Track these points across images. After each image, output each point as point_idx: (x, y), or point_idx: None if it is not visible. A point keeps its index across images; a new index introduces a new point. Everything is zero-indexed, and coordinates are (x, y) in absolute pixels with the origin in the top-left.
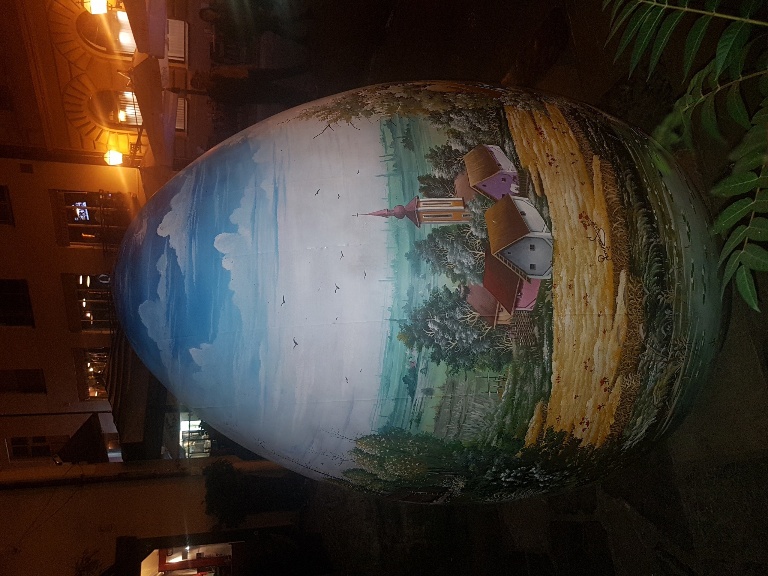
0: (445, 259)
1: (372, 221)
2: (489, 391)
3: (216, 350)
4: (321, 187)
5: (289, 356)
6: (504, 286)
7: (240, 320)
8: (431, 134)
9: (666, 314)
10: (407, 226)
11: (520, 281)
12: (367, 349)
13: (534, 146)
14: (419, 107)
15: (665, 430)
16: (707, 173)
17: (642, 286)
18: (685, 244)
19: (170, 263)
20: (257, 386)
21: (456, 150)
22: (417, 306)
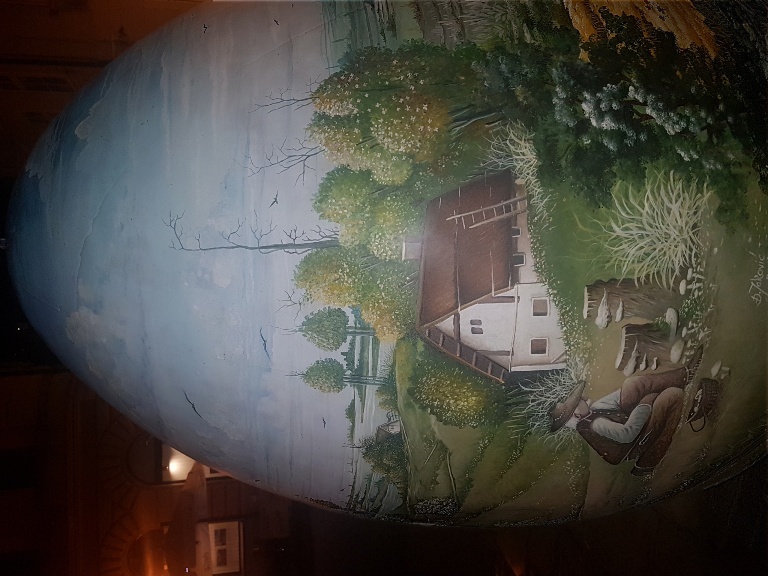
0: None
1: None
2: None
3: (108, 100)
4: None
5: (199, 41)
6: None
7: (140, 54)
8: None
9: None
10: None
11: None
12: None
13: None
14: None
15: None
16: None
17: None
18: None
19: None
20: (158, 99)
21: None
22: None
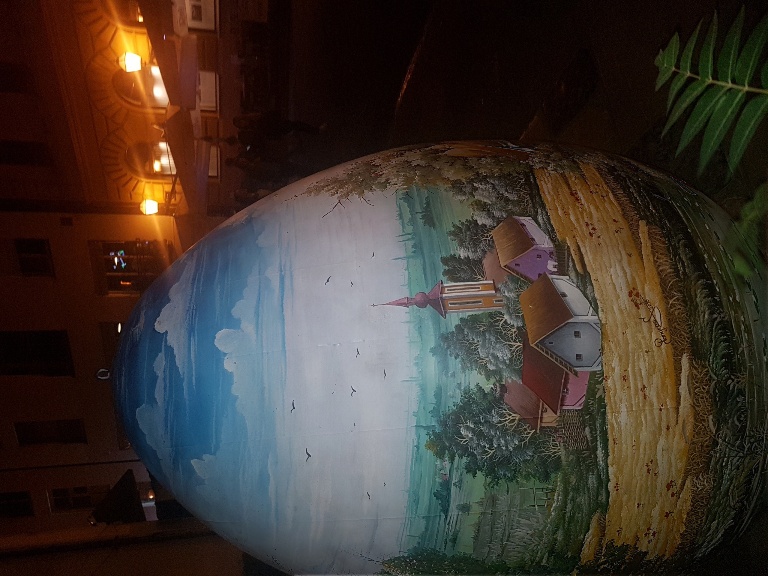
0: (476, 353)
1: (390, 312)
2: (536, 504)
3: (220, 462)
4: (332, 274)
5: (302, 469)
6: (547, 382)
7: (245, 429)
8: (453, 207)
9: (738, 401)
10: (431, 316)
11: (565, 375)
12: (391, 460)
13: (571, 215)
14: (438, 176)
15: (743, 531)
16: (762, 224)
17: (708, 371)
18: (753, 317)
19: (168, 363)
20: (267, 502)
21: (482, 225)
22: (446, 409)
